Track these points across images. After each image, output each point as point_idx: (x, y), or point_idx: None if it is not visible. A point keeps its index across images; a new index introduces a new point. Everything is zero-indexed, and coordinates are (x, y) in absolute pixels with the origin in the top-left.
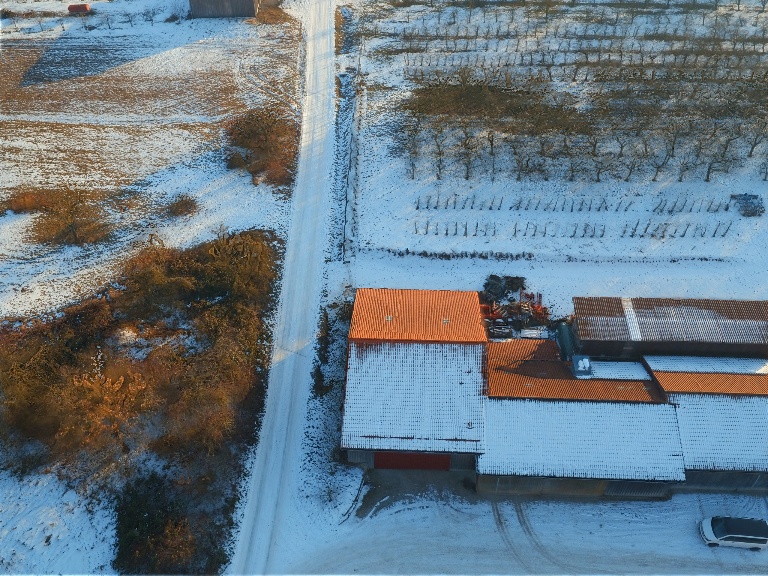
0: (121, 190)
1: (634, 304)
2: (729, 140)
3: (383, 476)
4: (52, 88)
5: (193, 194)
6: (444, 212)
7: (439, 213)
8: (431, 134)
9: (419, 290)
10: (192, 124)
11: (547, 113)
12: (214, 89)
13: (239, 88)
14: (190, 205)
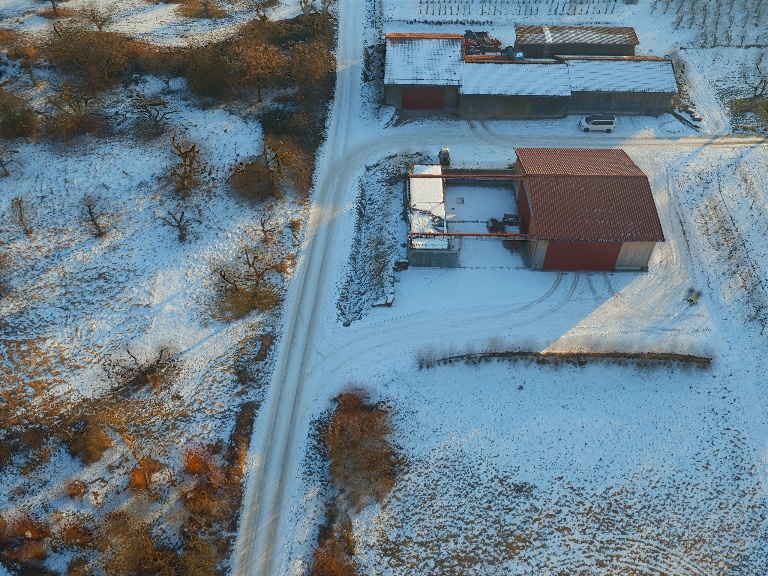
0: None
1: (550, 29)
2: None
3: (406, 112)
4: None
5: None
6: (438, 4)
7: (434, 5)
8: None
9: (424, 33)
10: None
11: None
12: None
13: None
14: (275, 2)
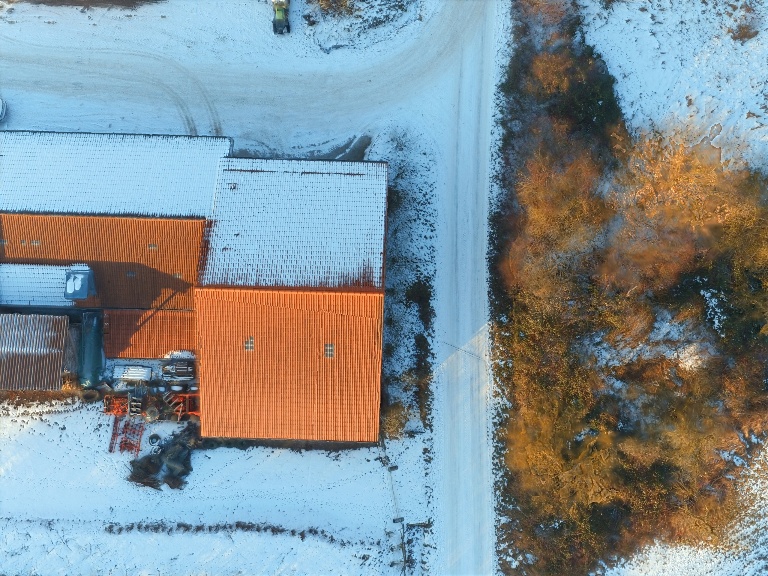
0: None
1: None
2: None
3: None
4: None
5: None
6: None
7: None
8: None
9: (287, 438)
10: None
11: None
12: None
13: None
14: None
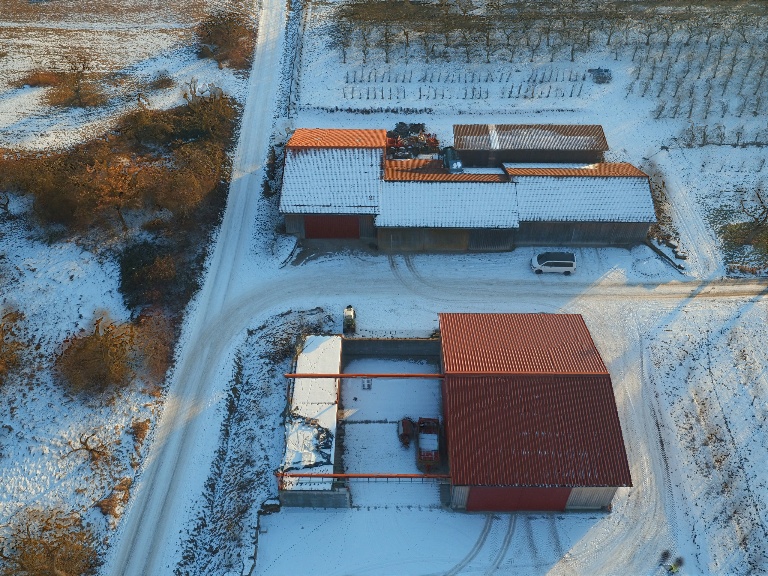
0: (114, 73)
1: (497, 128)
2: (590, 30)
3: (312, 243)
4: (54, 5)
5: (171, 75)
6: (367, 84)
7: (363, 85)
8: (361, 33)
9: (343, 129)
10: (169, 29)
11: (455, 19)
12: (187, 5)
13: (208, 4)
14: (169, 82)
